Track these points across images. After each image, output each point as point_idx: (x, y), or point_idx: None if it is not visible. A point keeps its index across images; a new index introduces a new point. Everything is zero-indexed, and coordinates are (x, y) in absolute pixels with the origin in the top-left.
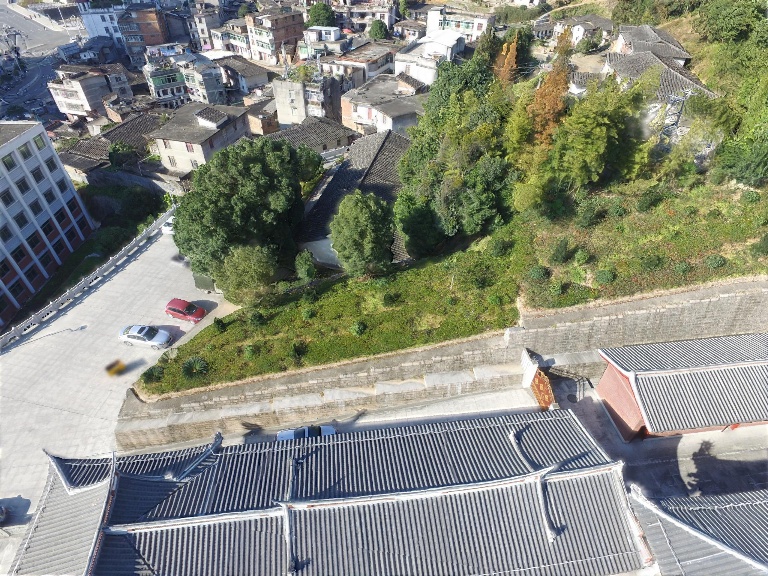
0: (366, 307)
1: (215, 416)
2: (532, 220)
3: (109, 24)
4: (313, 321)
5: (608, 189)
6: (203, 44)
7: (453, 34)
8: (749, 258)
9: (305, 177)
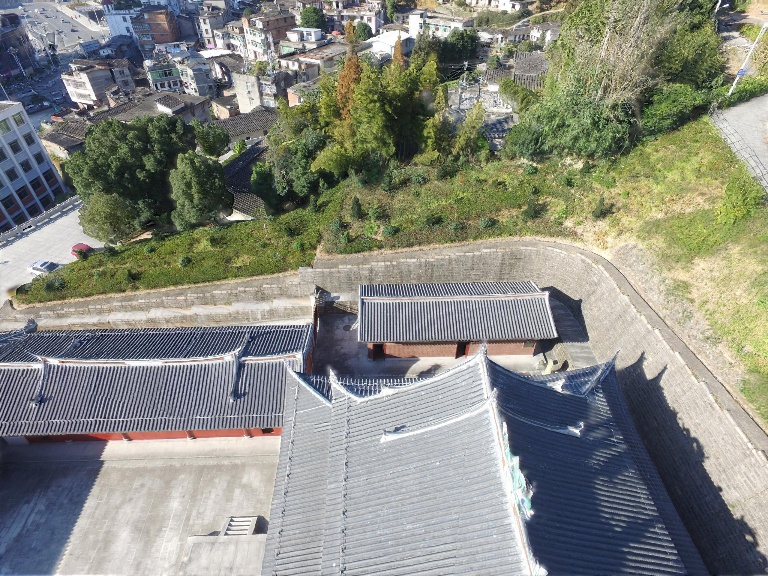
0: (197, 247)
1: (64, 322)
2: (351, 185)
3: (130, 24)
4: (152, 255)
5: (414, 161)
6: (207, 43)
7: (402, 35)
8: (520, 222)
9: (213, 152)
